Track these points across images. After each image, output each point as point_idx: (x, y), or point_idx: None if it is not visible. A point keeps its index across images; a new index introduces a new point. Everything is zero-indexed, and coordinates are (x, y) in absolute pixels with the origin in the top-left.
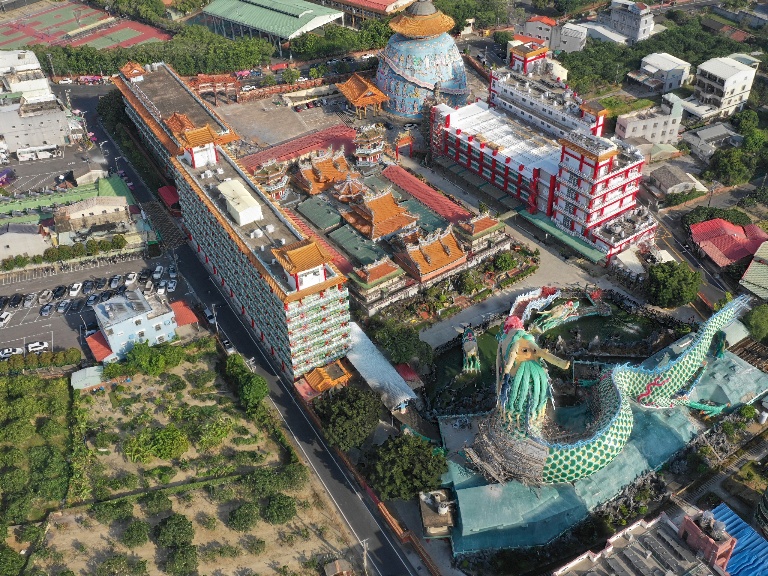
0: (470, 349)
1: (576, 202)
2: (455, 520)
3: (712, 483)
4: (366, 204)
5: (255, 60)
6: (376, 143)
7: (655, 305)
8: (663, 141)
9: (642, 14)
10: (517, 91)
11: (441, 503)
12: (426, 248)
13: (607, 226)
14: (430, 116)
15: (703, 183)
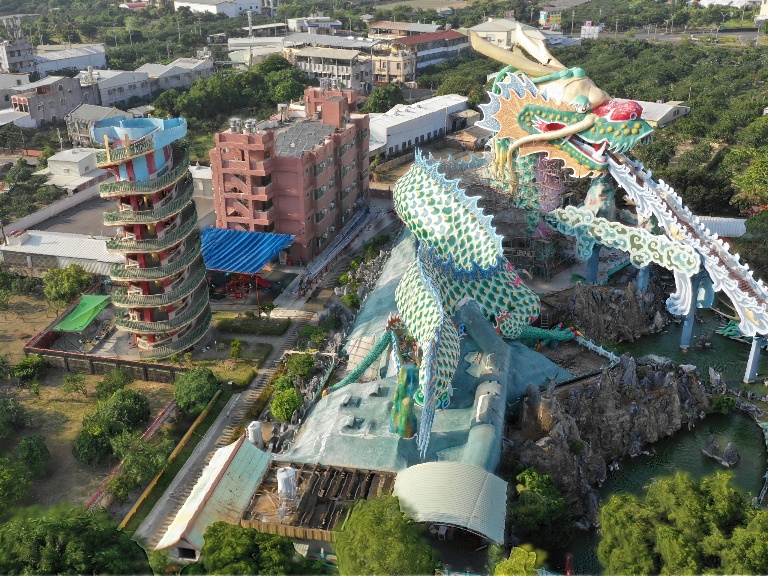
0: None
1: None
2: None
3: (286, 345)
4: None
5: None
6: None
7: None
8: None
9: None
10: None
11: None
12: None
13: None
14: None
15: None
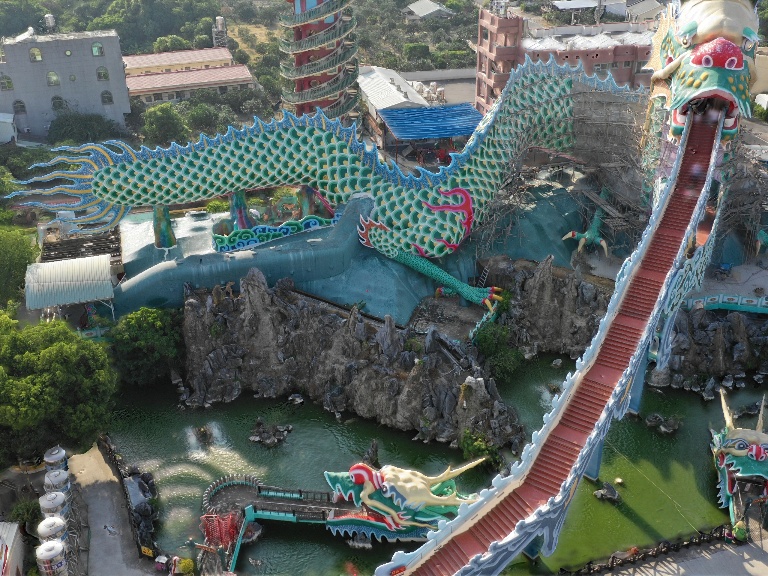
0: None
1: None
2: None
3: None
4: None
5: None
6: None
7: None
8: None
9: None
10: None
11: None
12: None
13: None
14: None
15: None
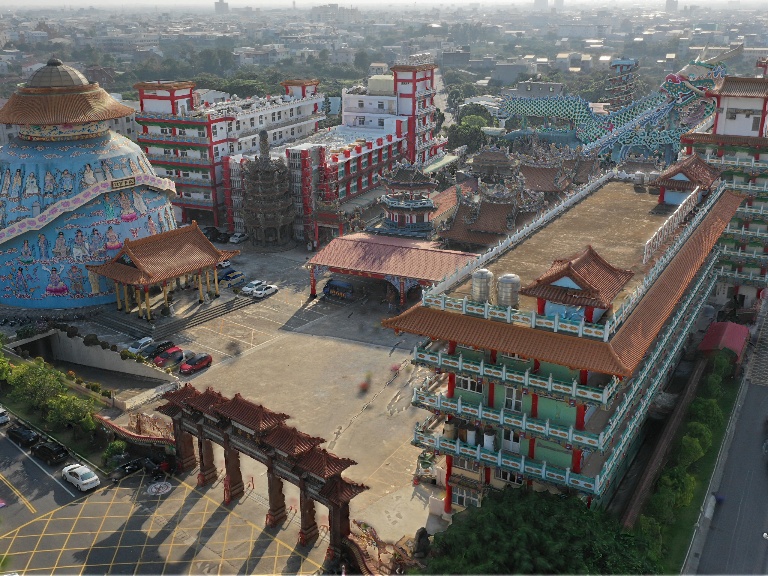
0: None
1: None
2: None
3: None
4: None
5: None
6: None
7: None
8: None
9: None
10: None
11: None
12: None
13: None
14: (308, 167)
15: None
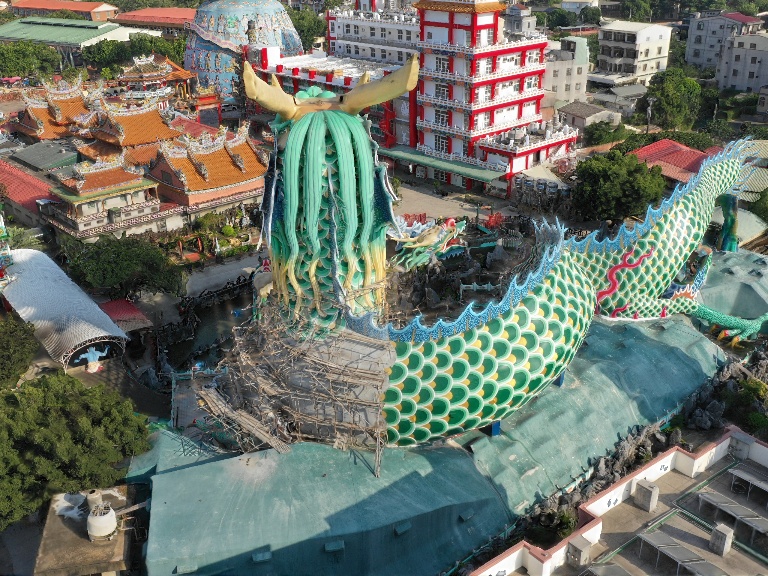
0: (264, 283)
1: (449, 100)
2: (133, 551)
3: None
4: (111, 118)
5: (30, 65)
6: (157, 87)
7: (594, 218)
8: (568, 100)
9: (523, 15)
10: (361, 19)
11: (95, 506)
12: (201, 158)
13: (501, 136)
14: (241, 61)
15: (631, 126)
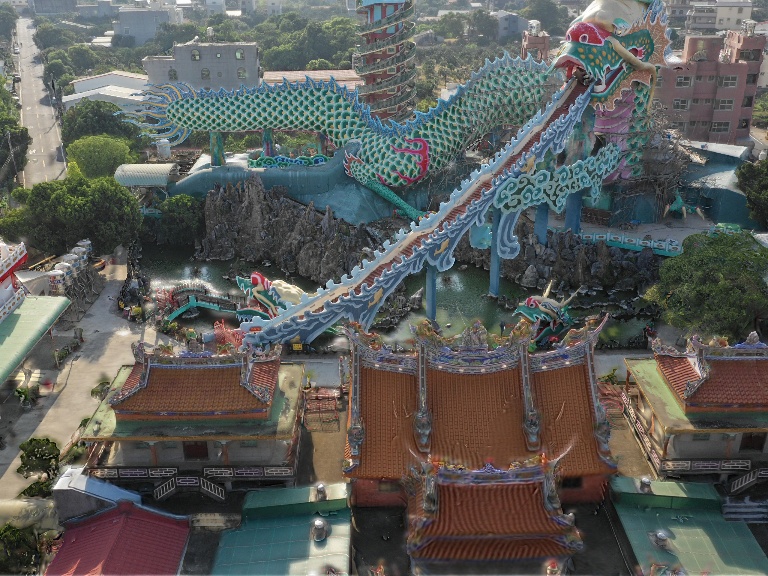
0: None
1: None
2: None
3: None
4: None
5: None
6: None
7: None
8: None
9: None
10: None
11: None
12: None
13: None
14: None
15: None
